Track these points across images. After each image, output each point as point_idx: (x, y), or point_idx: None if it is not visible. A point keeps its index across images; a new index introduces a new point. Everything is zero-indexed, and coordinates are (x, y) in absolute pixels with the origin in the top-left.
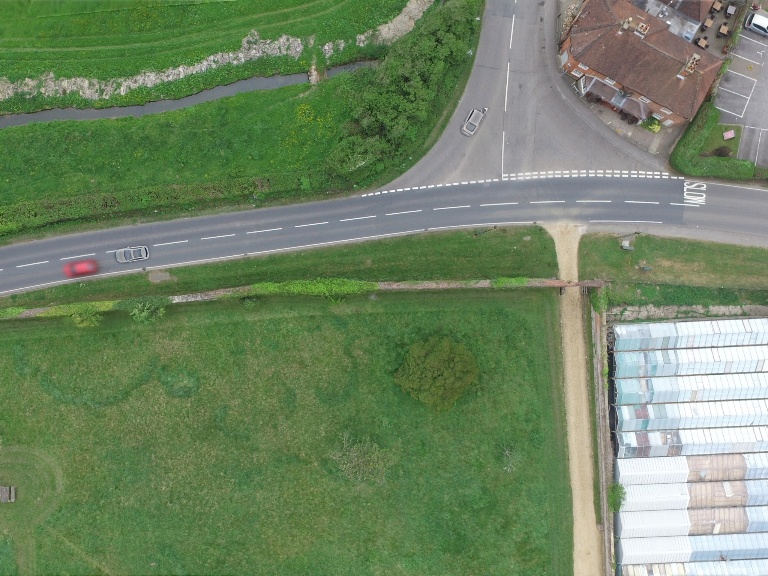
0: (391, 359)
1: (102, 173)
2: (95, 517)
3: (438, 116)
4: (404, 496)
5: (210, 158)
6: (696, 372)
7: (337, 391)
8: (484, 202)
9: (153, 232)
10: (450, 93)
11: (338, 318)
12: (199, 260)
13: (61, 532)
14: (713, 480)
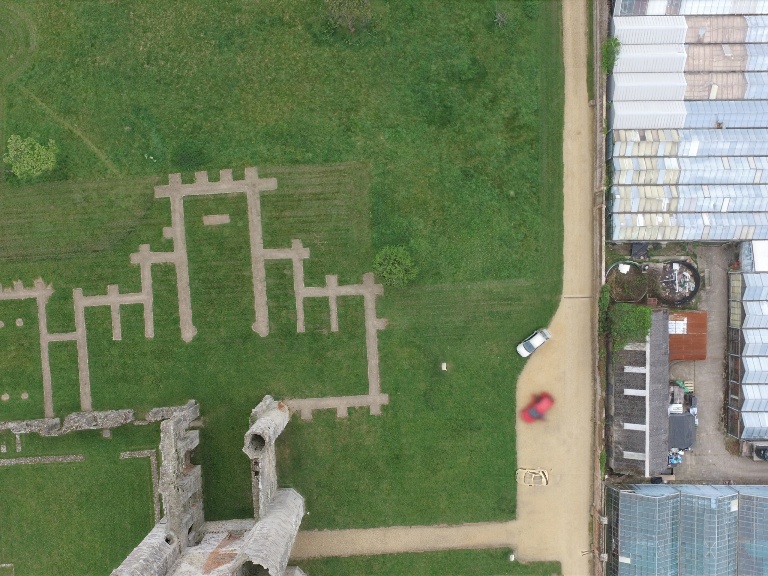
0: None
1: None
2: (69, 76)
3: None
4: (390, 64)
5: None
6: None
7: None
8: None
9: None
10: None
11: None
12: None
13: (33, 91)
14: (712, 42)
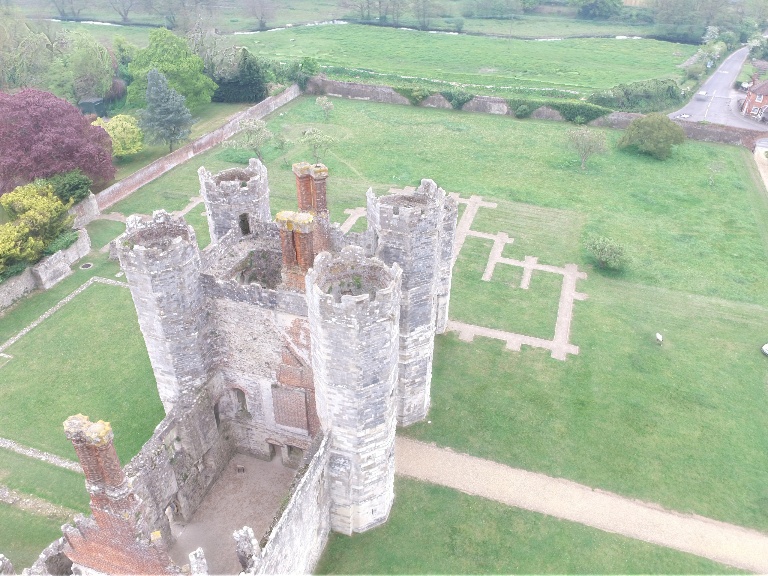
0: None
1: None
2: None
3: (660, 109)
4: (613, 183)
5: None
6: None
7: None
8: None
9: None
10: (669, 106)
11: None
12: None
13: (331, 148)
14: None
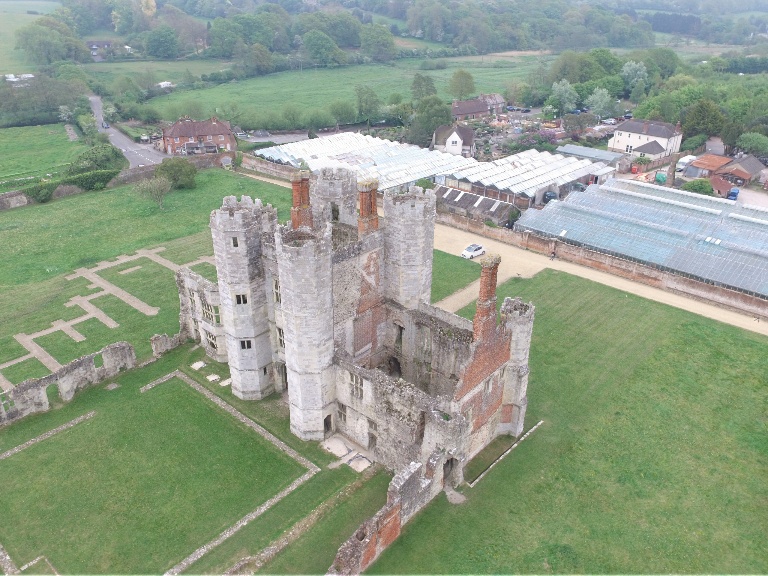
0: None
1: None
2: None
3: None
4: None
5: None
6: None
7: None
8: None
9: None
10: None
11: None
12: None
13: None
14: None
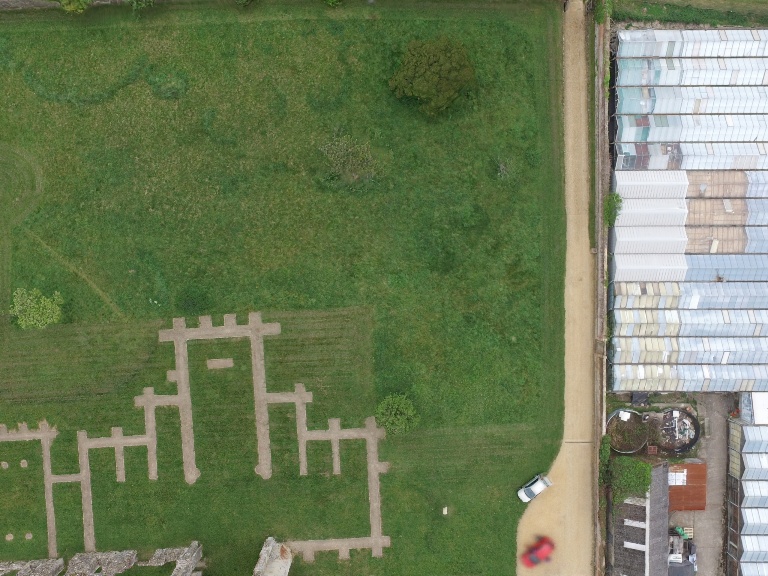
0: (386, 68)
1: None
2: (74, 219)
3: None
4: (393, 210)
5: None
6: (700, 82)
7: (329, 99)
8: None
9: None
10: None
11: (334, 22)
12: None
13: (38, 234)
14: (713, 197)
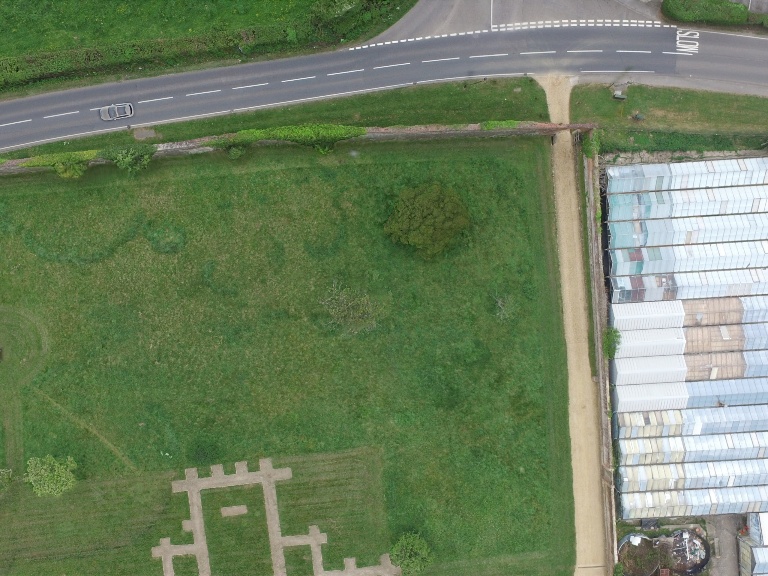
0: (381, 211)
1: (85, 30)
2: (82, 377)
3: None
4: (396, 350)
5: (194, 13)
6: (691, 213)
7: (326, 244)
8: (473, 54)
9: (137, 89)
10: None
11: (326, 169)
12: (185, 117)
13: (48, 393)
14: (709, 324)
